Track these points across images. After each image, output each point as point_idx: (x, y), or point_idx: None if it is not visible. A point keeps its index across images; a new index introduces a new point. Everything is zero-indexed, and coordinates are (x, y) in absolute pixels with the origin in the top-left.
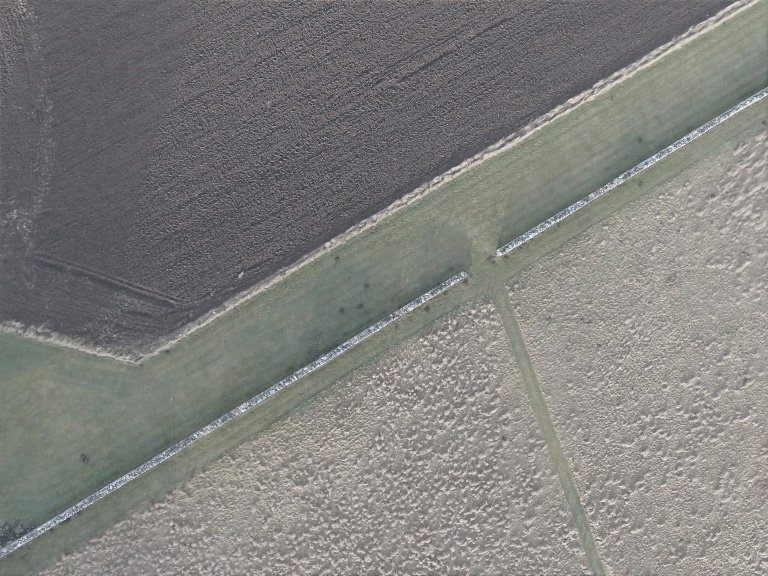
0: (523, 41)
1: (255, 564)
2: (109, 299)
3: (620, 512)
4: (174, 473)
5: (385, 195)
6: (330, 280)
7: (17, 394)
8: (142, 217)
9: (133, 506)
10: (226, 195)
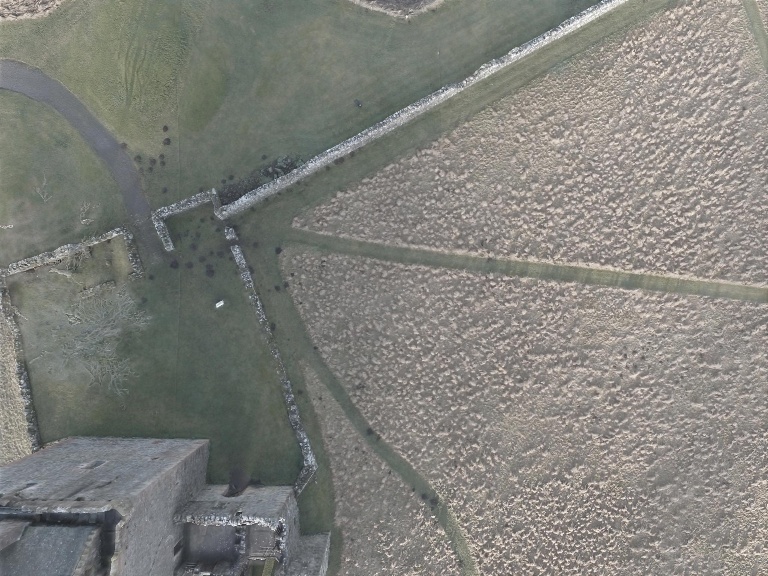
0: None
1: (513, 212)
2: None
3: None
4: (439, 123)
5: None
6: None
7: (297, 41)
8: None
9: (401, 152)
10: None
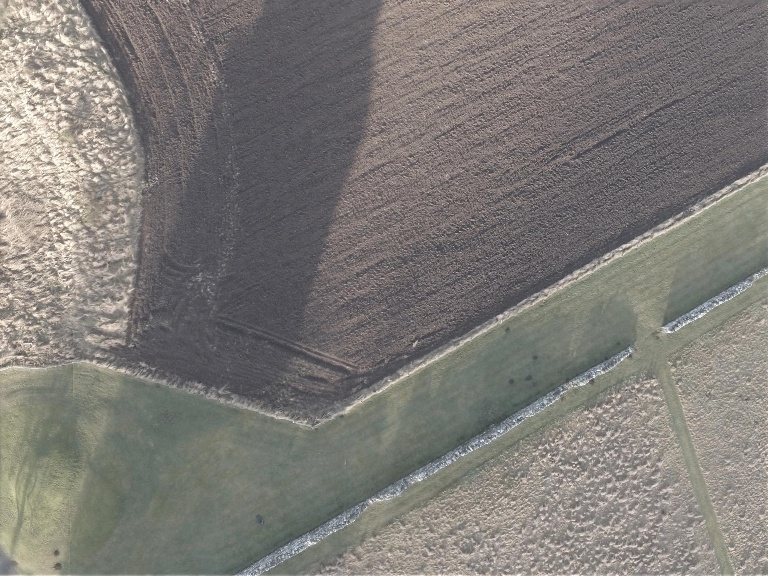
0: (694, 122)
1: None
2: (288, 363)
3: None
4: (345, 536)
5: (556, 269)
6: (500, 351)
7: (198, 454)
8: (321, 284)
9: (304, 567)
10: (403, 265)
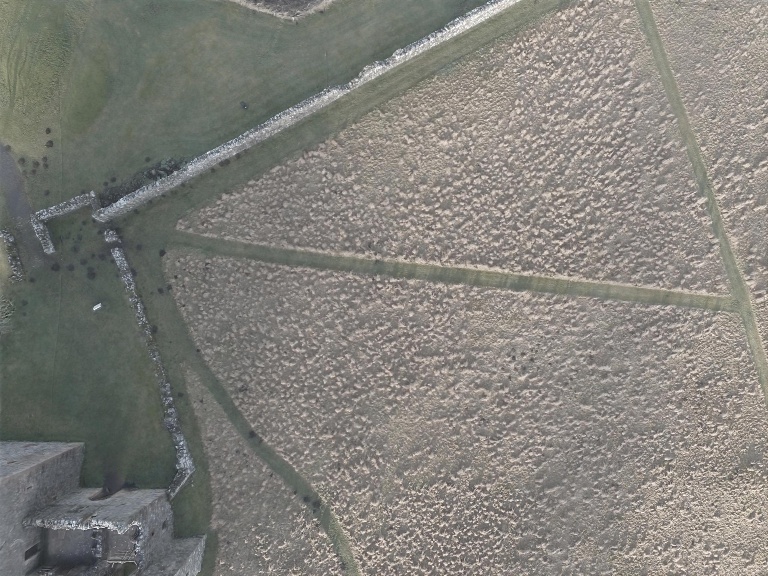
0: None
1: (401, 214)
2: None
3: (744, 189)
4: (326, 125)
5: None
6: None
7: (182, 42)
8: None
9: (288, 154)
10: None
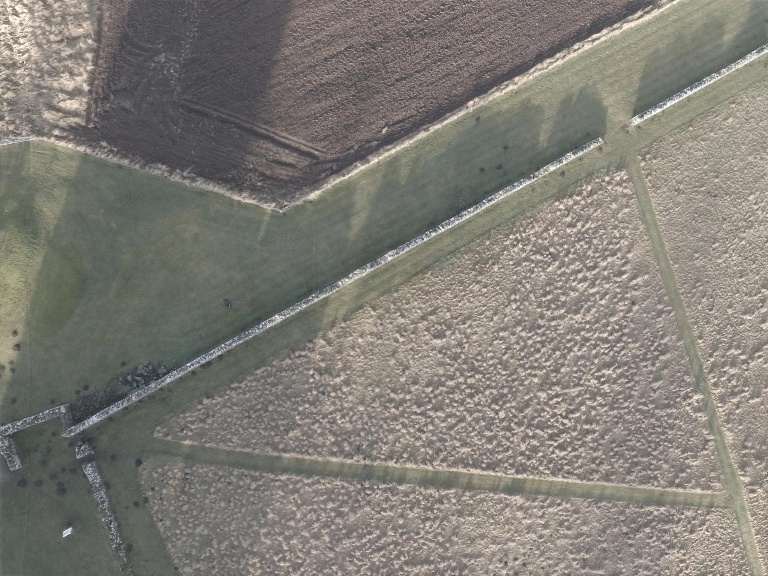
0: None
1: (392, 415)
2: (255, 147)
3: (740, 381)
4: (315, 322)
5: (526, 59)
6: (471, 140)
7: (162, 236)
8: (289, 68)
9: (273, 353)
10: (372, 50)
